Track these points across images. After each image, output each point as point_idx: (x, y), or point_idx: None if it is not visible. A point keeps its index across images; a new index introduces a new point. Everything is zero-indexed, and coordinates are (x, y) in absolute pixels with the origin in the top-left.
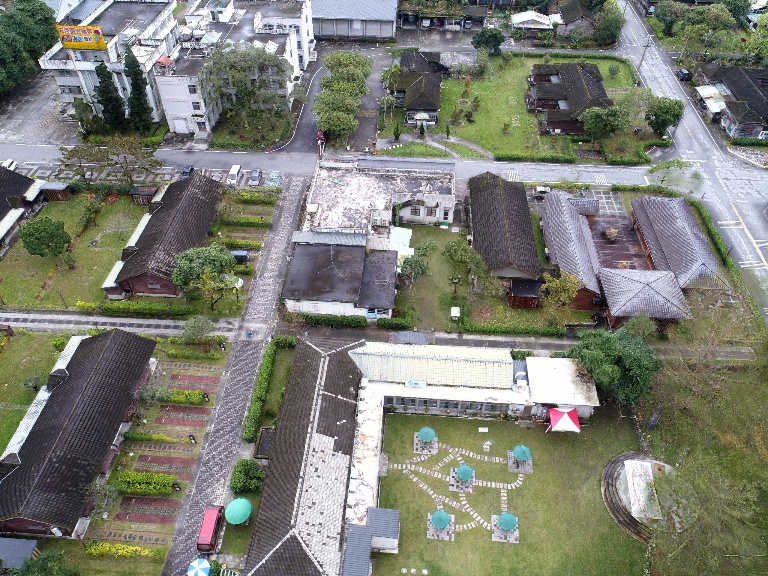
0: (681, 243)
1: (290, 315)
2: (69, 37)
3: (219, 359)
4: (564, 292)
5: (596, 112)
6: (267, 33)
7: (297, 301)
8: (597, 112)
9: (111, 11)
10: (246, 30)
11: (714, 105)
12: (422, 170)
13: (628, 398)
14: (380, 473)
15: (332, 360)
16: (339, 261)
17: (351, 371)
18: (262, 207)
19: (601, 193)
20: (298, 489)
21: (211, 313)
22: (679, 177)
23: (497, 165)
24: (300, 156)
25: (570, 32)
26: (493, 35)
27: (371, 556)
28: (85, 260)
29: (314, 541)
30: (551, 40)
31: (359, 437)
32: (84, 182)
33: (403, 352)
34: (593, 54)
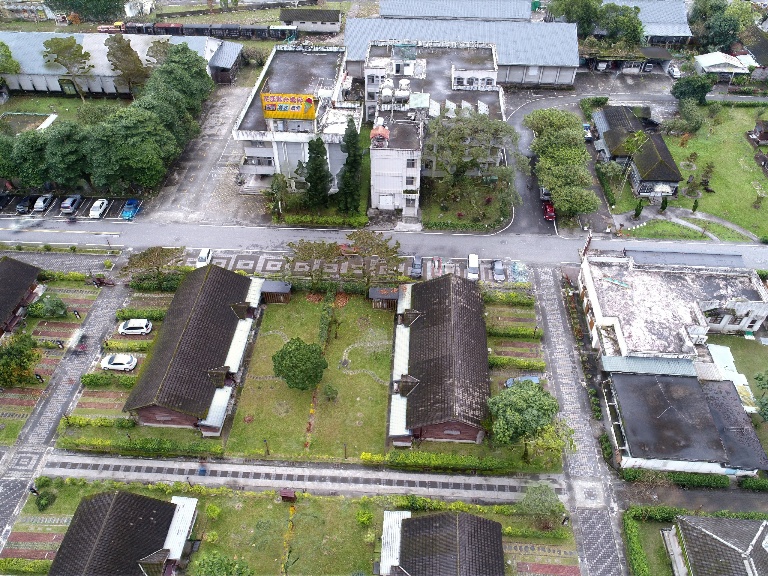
0: None
1: (634, 474)
2: (273, 106)
3: (565, 538)
4: None
5: None
6: (466, 90)
7: (648, 459)
8: None
9: (279, 63)
10: (440, 86)
11: None
12: (716, 268)
13: None
14: None
15: (756, 562)
16: (675, 399)
17: None
18: (519, 310)
19: None
20: None
21: (527, 467)
22: None
23: None
24: (534, 239)
25: None
26: (701, 85)
27: None
28: (342, 388)
29: None
30: None
31: None
32: (298, 276)
33: None
34: None
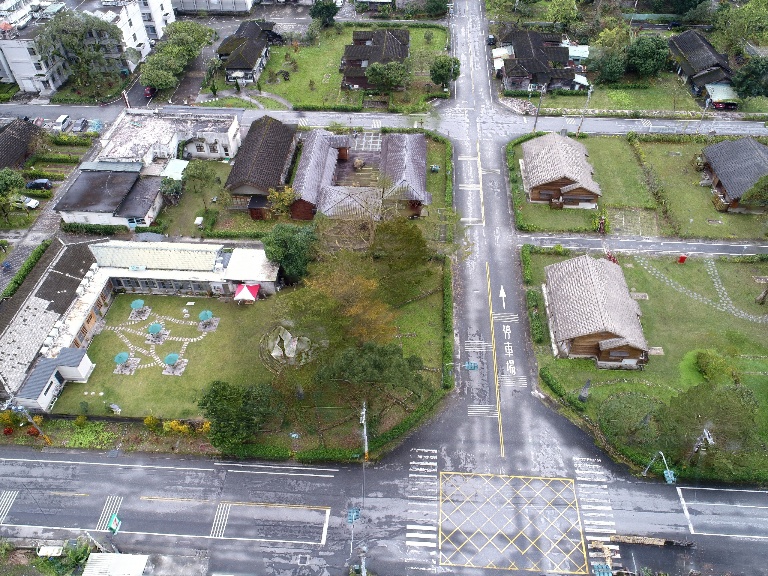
0: (398, 166)
1: (64, 225)
2: None
3: None
4: (281, 202)
5: (371, 66)
6: (113, 5)
7: (67, 212)
8: (372, 66)
9: None
10: (96, 3)
11: (499, 63)
12: (210, 114)
13: (292, 273)
14: (95, 332)
15: (70, 249)
16: (112, 183)
17: (86, 258)
18: (78, 148)
19: (371, 135)
20: (4, 331)
21: (4, 225)
22: (444, 121)
23: (293, 114)
24: None
25: (405, 5)
26: (325, 7)
27: (65, 385)
28: None
29: (5, 364)
30: (387, 12)
31: (77, 304)
32: None
33: (134, 245)
34: (419, 23)
